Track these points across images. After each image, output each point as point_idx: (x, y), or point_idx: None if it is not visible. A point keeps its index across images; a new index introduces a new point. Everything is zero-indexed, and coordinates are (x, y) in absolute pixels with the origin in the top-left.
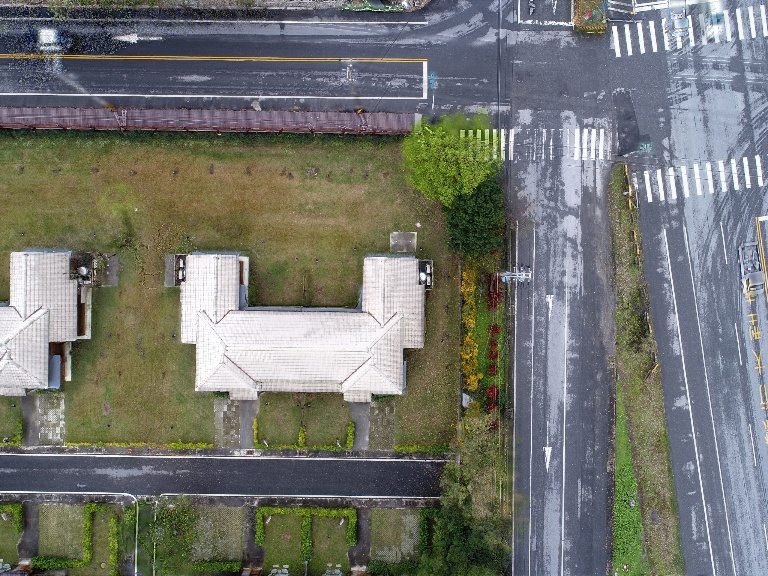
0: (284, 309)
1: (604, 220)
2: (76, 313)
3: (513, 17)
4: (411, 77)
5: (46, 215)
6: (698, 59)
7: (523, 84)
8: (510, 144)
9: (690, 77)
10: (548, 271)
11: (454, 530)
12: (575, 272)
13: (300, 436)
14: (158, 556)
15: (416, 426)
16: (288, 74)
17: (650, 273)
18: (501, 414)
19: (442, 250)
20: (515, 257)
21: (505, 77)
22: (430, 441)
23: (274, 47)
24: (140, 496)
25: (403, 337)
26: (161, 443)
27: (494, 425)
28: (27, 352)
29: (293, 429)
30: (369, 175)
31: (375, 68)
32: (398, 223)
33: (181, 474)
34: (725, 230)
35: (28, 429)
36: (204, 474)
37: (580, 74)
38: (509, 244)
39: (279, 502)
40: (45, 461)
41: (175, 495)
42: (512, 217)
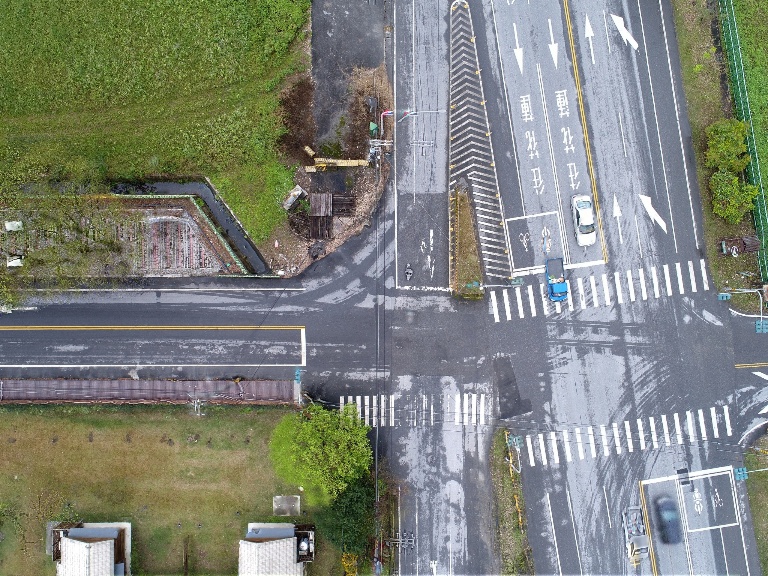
0: None
1: (487, 484)
2: None
3: (391, 283)
4: (289, 344)
5: None
6: (577, 323)
7: (402, 350)
8: (390, 410)
9: (570, 341)
10: (431, 537)
11: None
12: (459, 537)
13: None
14: None
15: None
16: (165, 342)
17: (534, 537)
18: None
19: (326, 513)
20: (398, 523)
21: (384, 343)
22: None
23: (150, 315)
24: None
25: None
26: None
27: None
28: None
29: None
30: (250, 440)
31: (253, 336)
32: (281, 487)
33: None
34: (608, 494)
35: None
36: None
37: (459, 339)
38: (392, 510)
39: None
40: None
41: None
42: (394, 483)
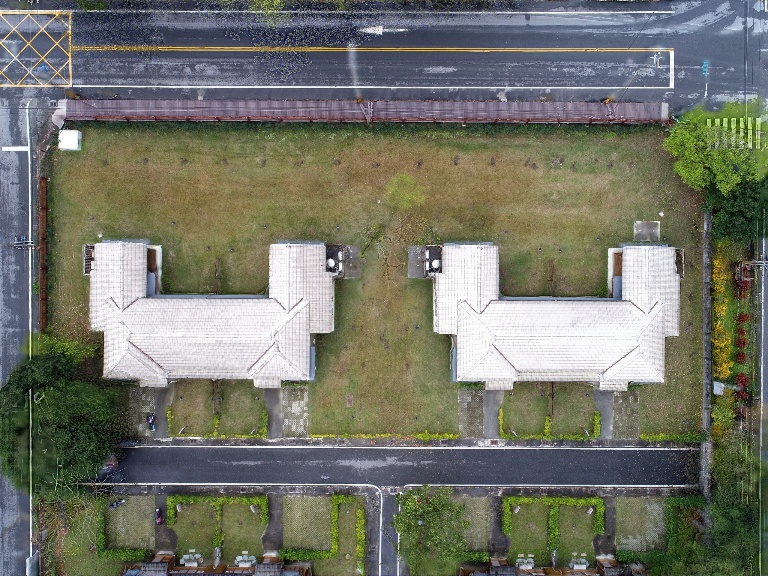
0: (544, 299)
1: None
2: (331, 305)
3: (760, 6)
4: None
5: (288, 208)
6: None
7: None
8: (757, 132)
9: None
10: None
11: (700, 518)
12: None
13: (546, 426)
14: (402, 547)
15: (660, 415)
16: (534, 65)
17: None
18: (748, 402)
19: (685, 239)
20: (762, 245)
21: (752, 66)
22: (675, 430)
23: (520, 38)
24: (384, 487)
25: (665, 325)
26: (405, 434)
27: (741, 413)
28: (292, 344)
29: (537, 419)
30: (613, 165)
31: (622, 58)
32: (641, 212)
33: (425, 465)
34: None
35: (272, 421)
36: (448, 465)
37: None
38: (756, 232)
39: (523, 492)
40: (289, 453)
41: (419, 486)
42: (759, 205)
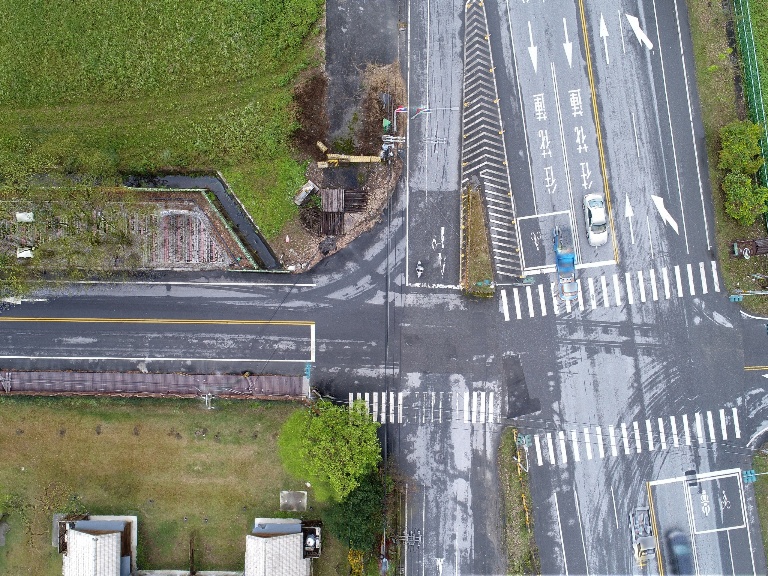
0: None
1: (494, 483)
2: None
3: (401, 280)
4: (299, 340)
5: None
6: (587, 323)
7: (412, 347)
8: (399, 407)
9: (580, 341)
10: (438, 534)
11: None
12: (465, 535)
13: None
14: None
15: None
16: (174, 336)
17: (541, 537)
18: None
19: (333, 509)
20: (405, 520)
21: (393, 340)
22: None
23: (160, 309)
24: None
25: None
26: None
27: None
28: None
29: None
30: (258, 435)
31: (262, 330)
32: (288, 482)
33: None
34: (616, 495)
35: None
36: None
37: (469, 337)
38: (399, 507)
39: None
40: None
41: None
42: (401, 480)
